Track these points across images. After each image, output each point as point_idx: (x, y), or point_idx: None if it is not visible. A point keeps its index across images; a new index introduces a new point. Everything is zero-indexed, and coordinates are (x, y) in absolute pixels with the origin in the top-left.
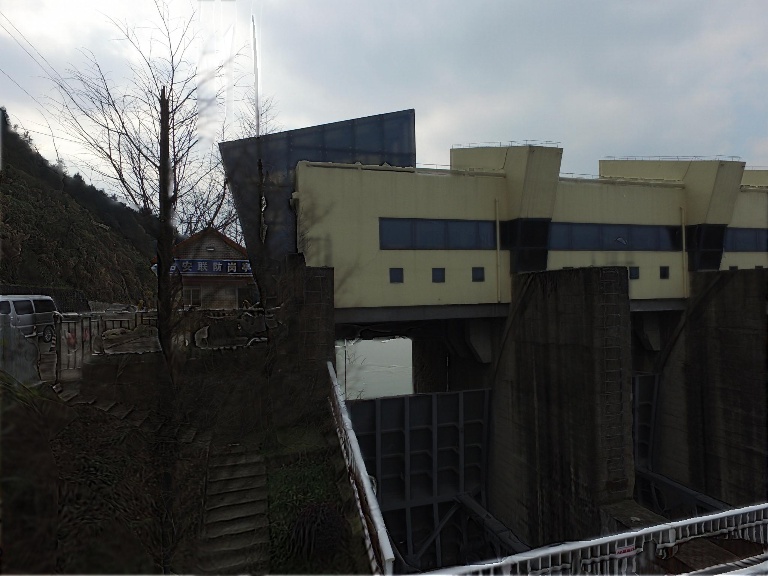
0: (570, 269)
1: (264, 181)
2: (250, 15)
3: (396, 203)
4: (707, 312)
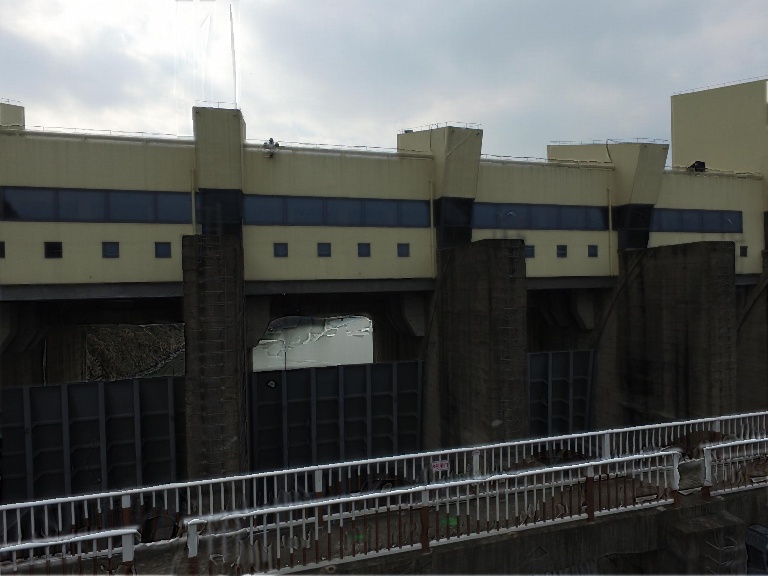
0: None
1: None
2: (229, 5)
3: None
4: None
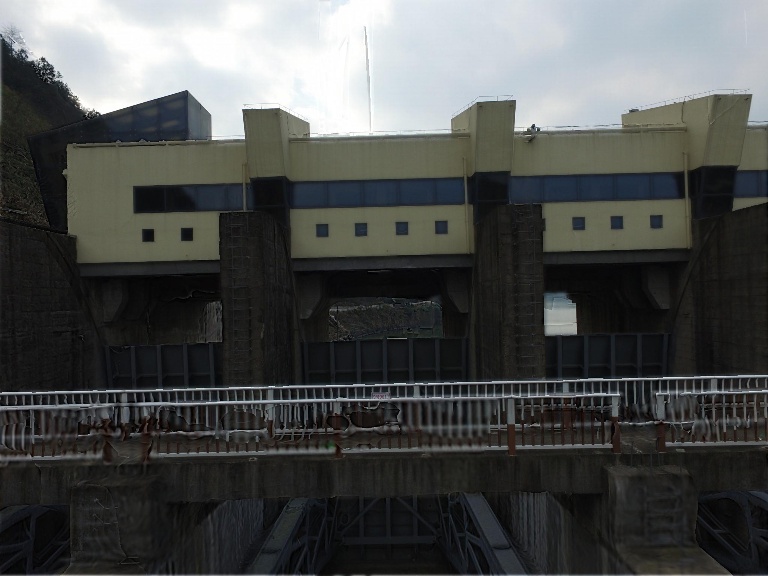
0: None
1: (60, 164)
2: (363, 26)
3: (149, 173)
4: (478, 267)
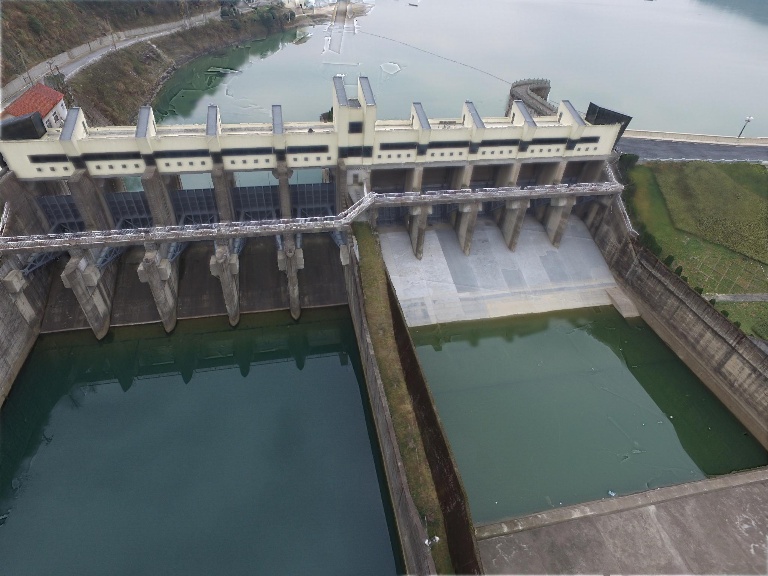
0: (68, 179)
1: None
2: None
3: None
4: None
